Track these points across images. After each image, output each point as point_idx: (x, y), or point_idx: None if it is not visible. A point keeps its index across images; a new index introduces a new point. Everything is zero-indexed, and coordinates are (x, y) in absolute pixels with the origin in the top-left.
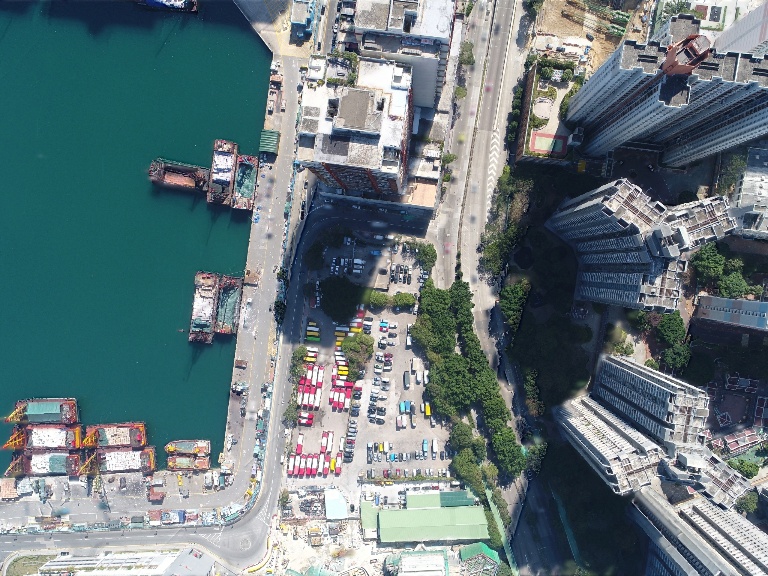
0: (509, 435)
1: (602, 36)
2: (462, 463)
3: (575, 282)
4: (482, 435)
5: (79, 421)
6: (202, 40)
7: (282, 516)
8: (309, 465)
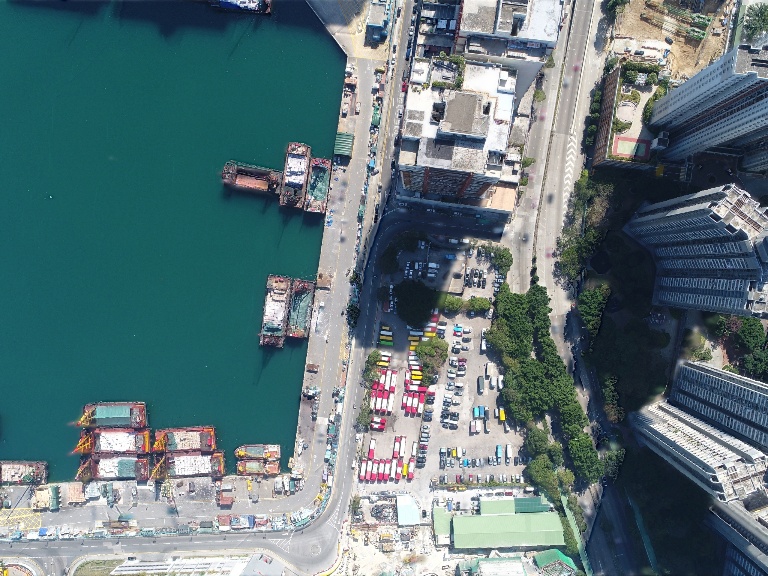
0: (586, 441)
1: (681, 39)
2: (538, 469)
3: (653, 287)
4: (557, 441)
5: (148, 425)
6: (275, 42)
7: (353, 521)
8: (381, 470)
